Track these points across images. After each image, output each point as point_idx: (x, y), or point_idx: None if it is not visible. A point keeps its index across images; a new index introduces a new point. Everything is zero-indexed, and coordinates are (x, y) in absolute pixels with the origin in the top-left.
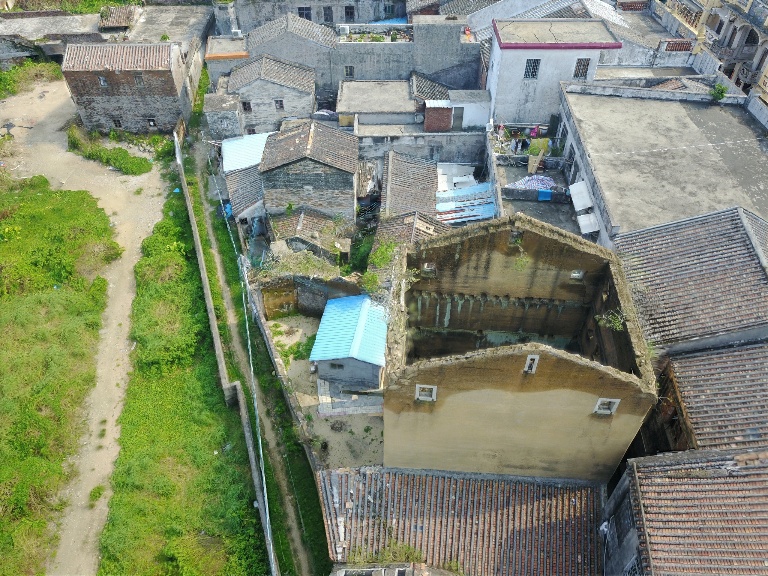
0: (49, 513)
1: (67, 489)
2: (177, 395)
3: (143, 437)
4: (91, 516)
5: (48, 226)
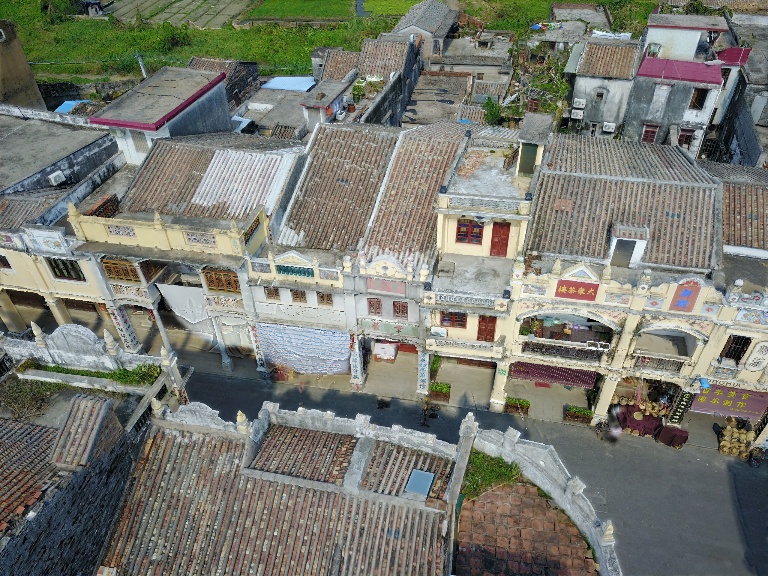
0: (110, 72)
1: (117, 75)
2: None
3: None
4: None
5: (304, 59)
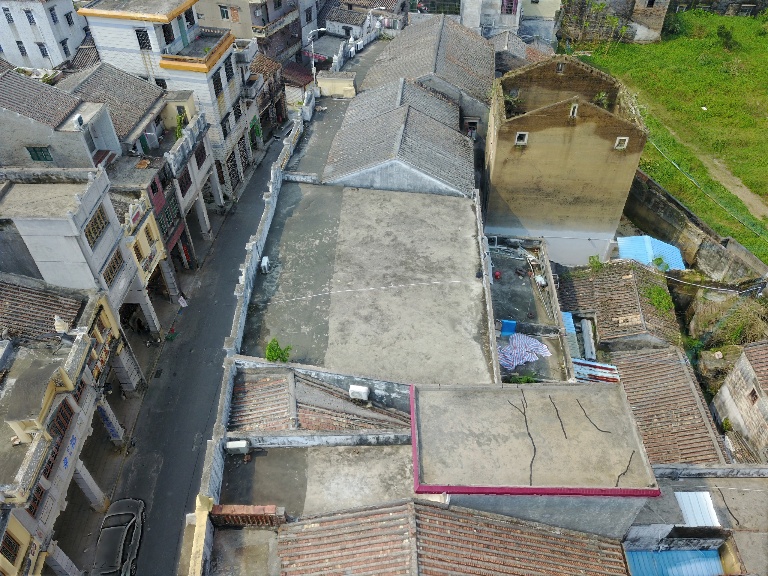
0: None
1: None
2: (767, 264)
3: (766, 242)
4: (759, 214)
5: None
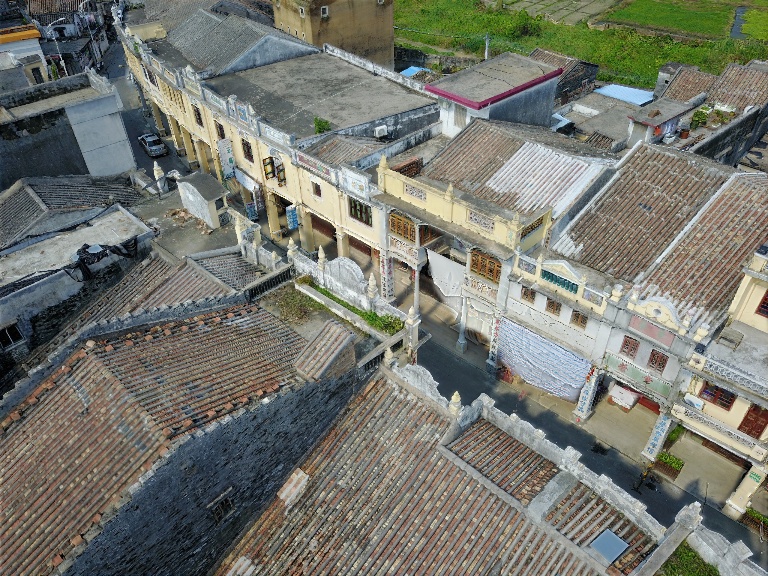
0: None
1: (462, 52)
2: None
3: None
4: None
5: None
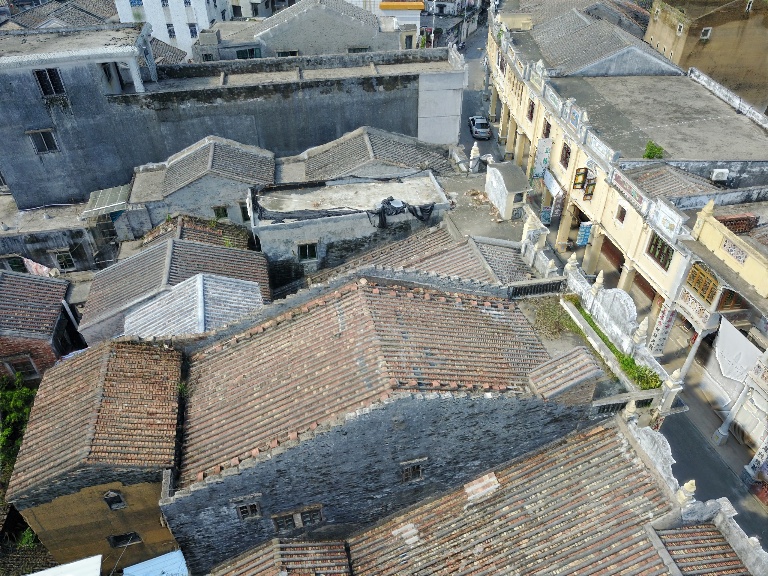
0: None
1: None
2: None
3: None
4: None
5: None
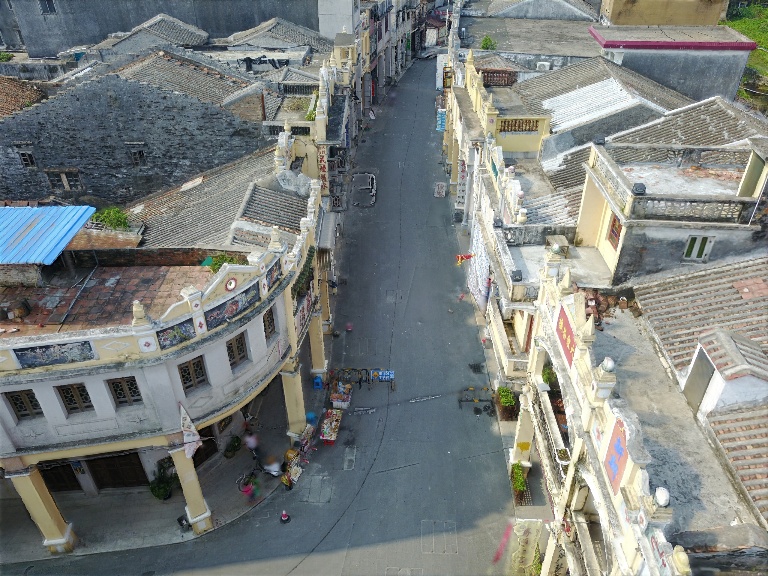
0: None
1: None
2: None
3: None
4: None
5: None
